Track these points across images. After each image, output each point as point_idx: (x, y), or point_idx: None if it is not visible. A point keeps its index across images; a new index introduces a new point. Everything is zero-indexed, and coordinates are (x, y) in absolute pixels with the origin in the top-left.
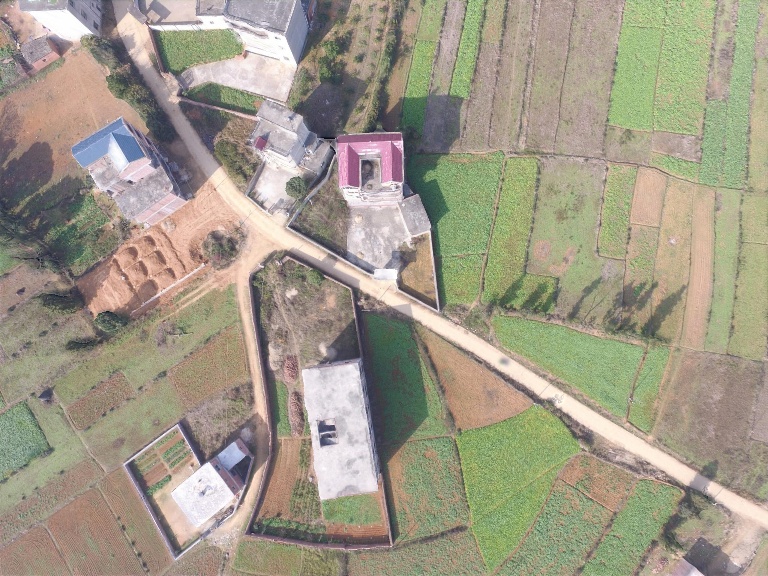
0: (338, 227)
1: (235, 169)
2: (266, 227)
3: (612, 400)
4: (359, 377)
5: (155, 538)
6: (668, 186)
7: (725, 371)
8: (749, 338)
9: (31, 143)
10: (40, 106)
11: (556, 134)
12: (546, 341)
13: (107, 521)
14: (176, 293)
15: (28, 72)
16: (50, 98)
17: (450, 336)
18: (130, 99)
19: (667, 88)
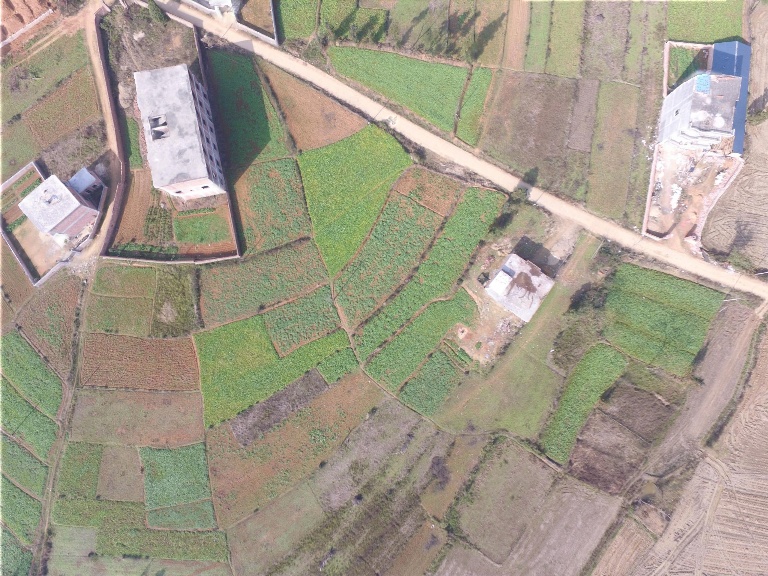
0: None
1: None
2: None
3: (440, 116)
4: (187, 76)
5: (16, 271)
6: None
7: (543, 88)
8: (564, 58)
9: None
10: None
11: None
12: (378, 66)
13: None
14: (27, 40)
15: None
16: None
17: (290, 68)
18: None
19: None
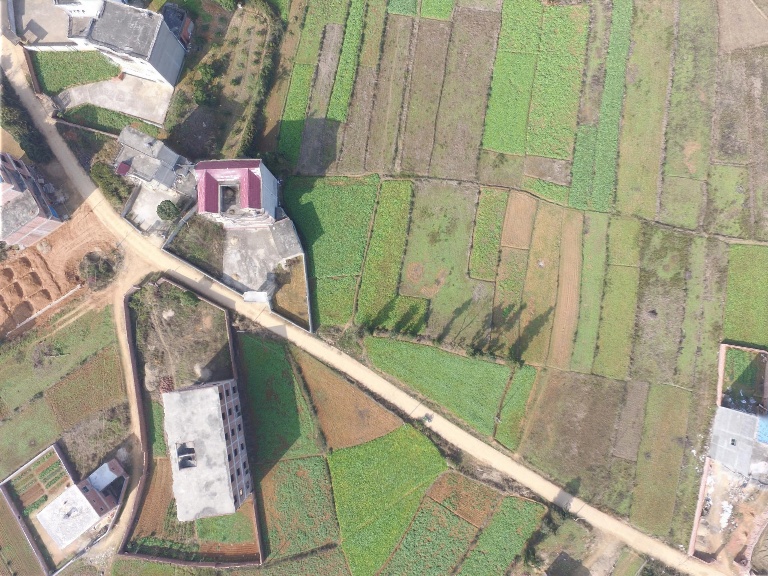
0: (214, 249)
1: (110, 191)
2: (143, 248)
3: (479, 419)
4: (218, 400)
5: (31, 558)
6: (538, 209)
7: (589, 390)
8: (613, 358)
9: None
10: None
11: (431, 157)
12: (416, 361)
13: None
14: (53, 314)
15: None
16: None
17: (324, 357)
18: None
19: (540, 113)
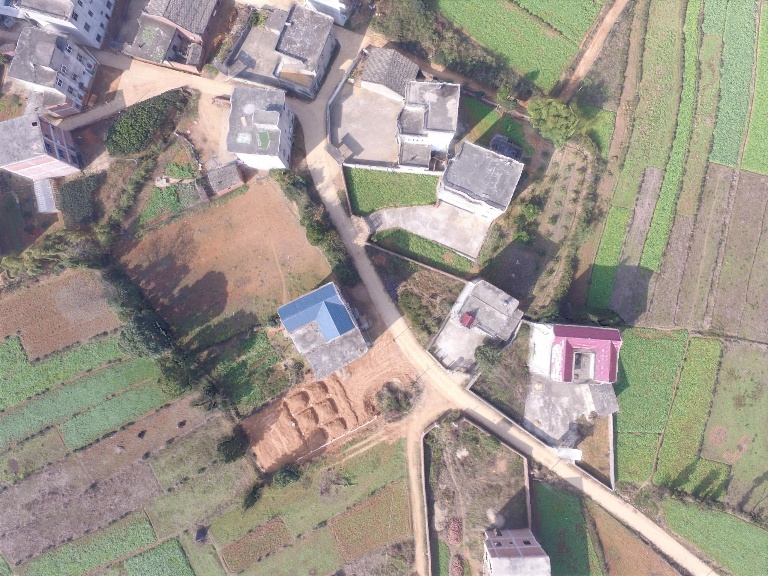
0: (518, 393)
1: (419, 324)
2: (443, 384)
3: None
4: (549, 571)
5: None
6: None
7: None
8: None
9: (205, 271)
10: (218, 233)
11: (741, 317)
12: (714, 529)
13: None
14: (344, 442)
15: (210, 198)
16: (229, 226)
17: (618, 513)
18: (326, 248)
19: None
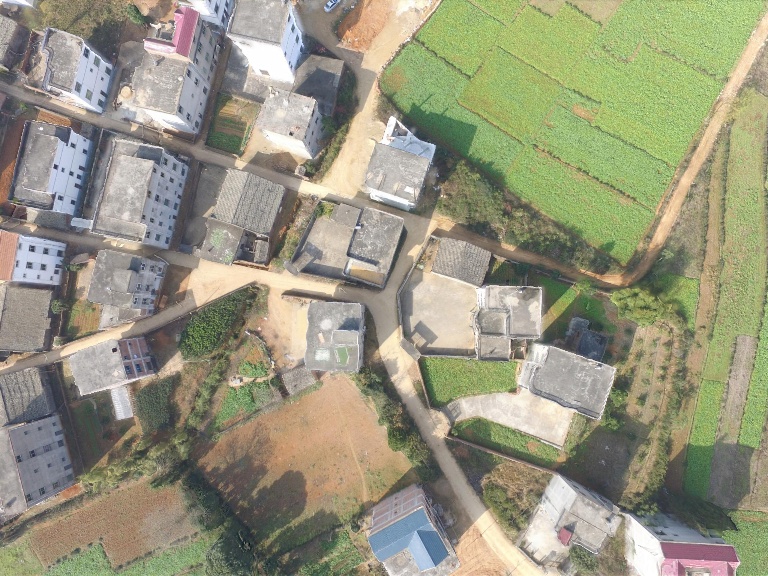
0: None
1: (507, 519)
2: None
3: None
4: None
5: None
6: None
7: None
8: None
9: (283, 471)
10: (294, 431)
11: None
12: None
13: None
14: None
15: (285, 397)
16: (305, 423)
17: None
18: (409, 454)
19: None
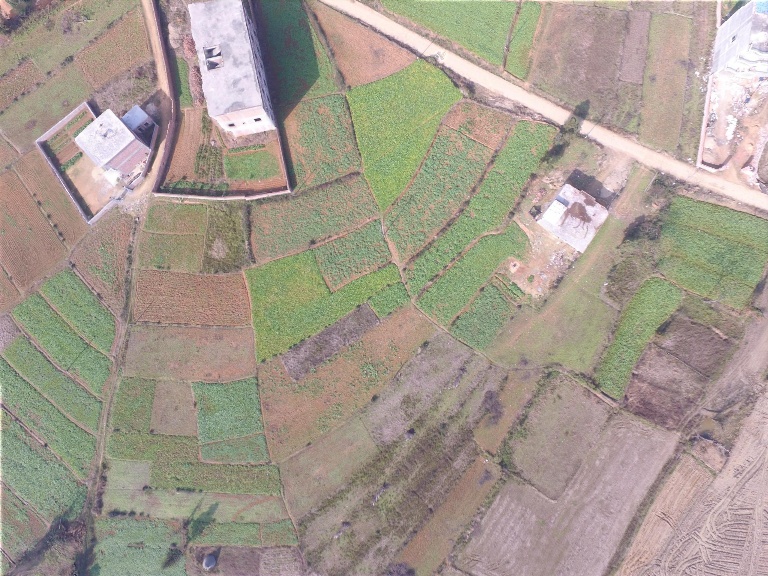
0: None
1: None
2: None
3: (489, 50)
4: (241, 7)
5: (69, 210)
6: None
7: (593, 21)
8: None
9: None
10: None
11: None
12: (426, 2)
13: (23, 199)
14: None
15: None
16: None
17: (338, 5)
18: None
19: None
